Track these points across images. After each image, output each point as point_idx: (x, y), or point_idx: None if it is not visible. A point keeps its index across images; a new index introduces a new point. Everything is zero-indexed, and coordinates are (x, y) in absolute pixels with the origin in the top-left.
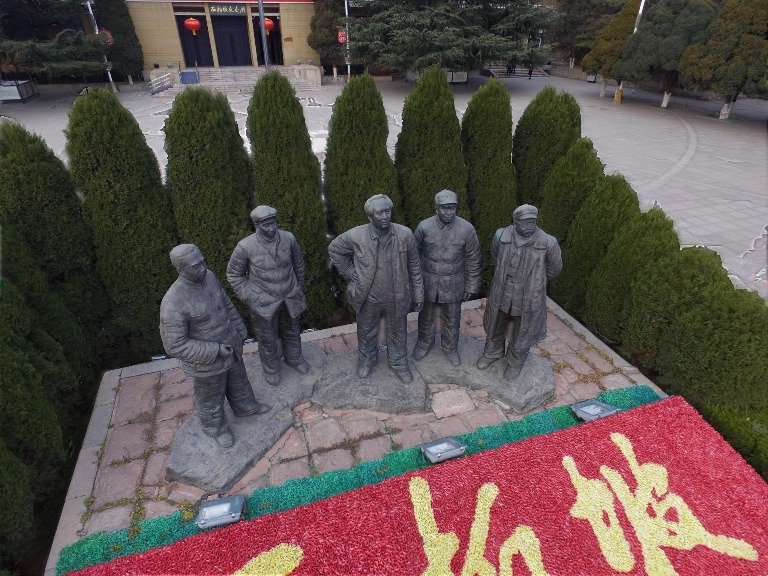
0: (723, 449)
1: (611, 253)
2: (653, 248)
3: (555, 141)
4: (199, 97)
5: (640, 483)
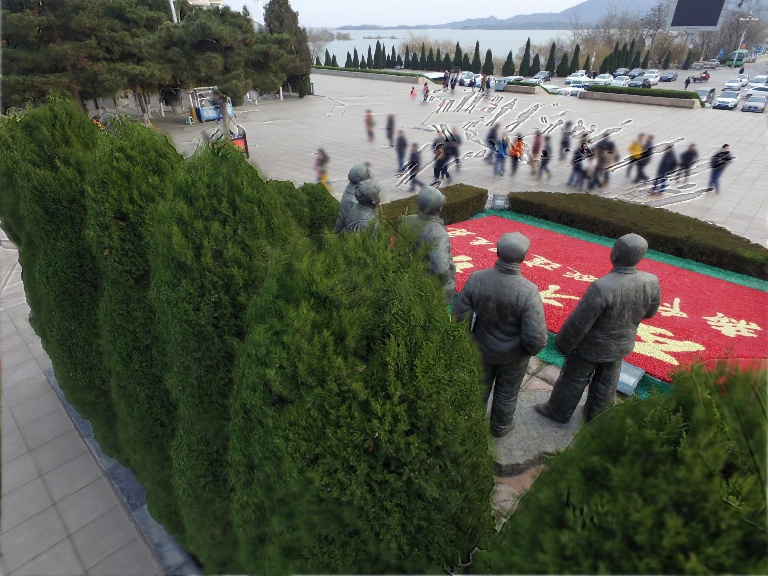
0: None
1: None
2: None
3: None
4: None
5: None
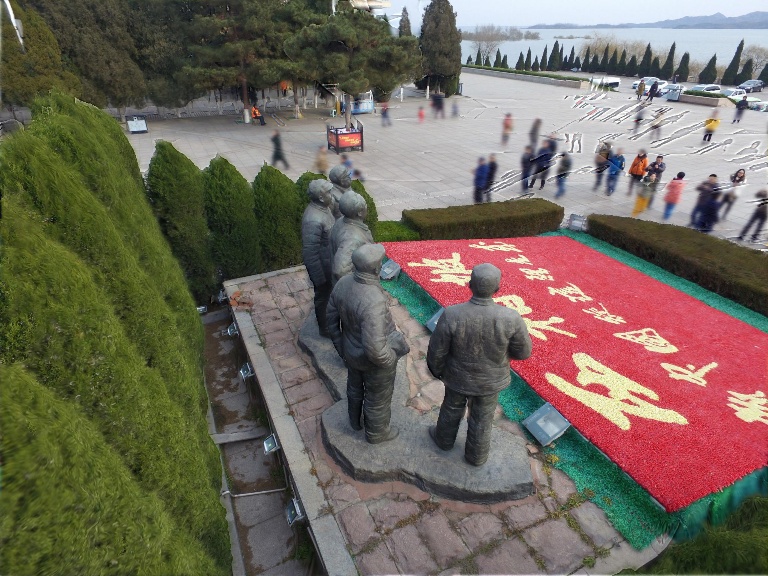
0: (406, 243)
1: (272, 207)
2: (290, 187)
3: (132, 154)
4: (22, 221)
5: (436, 266)
